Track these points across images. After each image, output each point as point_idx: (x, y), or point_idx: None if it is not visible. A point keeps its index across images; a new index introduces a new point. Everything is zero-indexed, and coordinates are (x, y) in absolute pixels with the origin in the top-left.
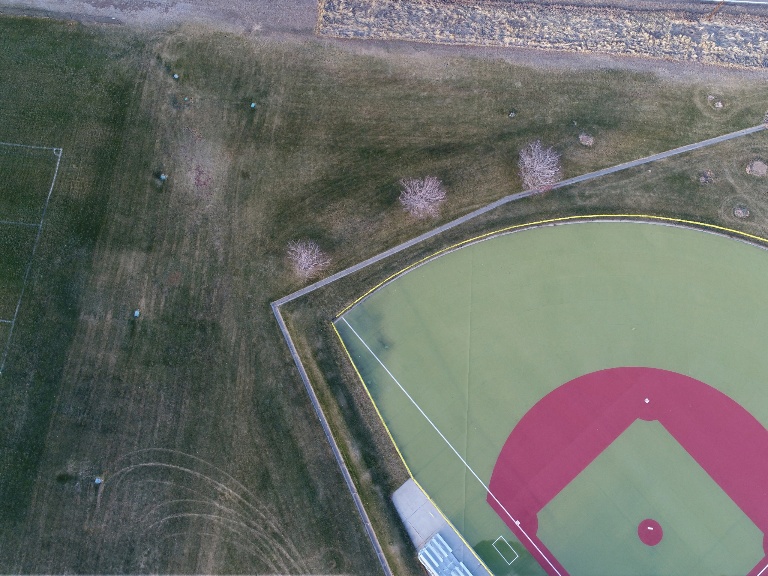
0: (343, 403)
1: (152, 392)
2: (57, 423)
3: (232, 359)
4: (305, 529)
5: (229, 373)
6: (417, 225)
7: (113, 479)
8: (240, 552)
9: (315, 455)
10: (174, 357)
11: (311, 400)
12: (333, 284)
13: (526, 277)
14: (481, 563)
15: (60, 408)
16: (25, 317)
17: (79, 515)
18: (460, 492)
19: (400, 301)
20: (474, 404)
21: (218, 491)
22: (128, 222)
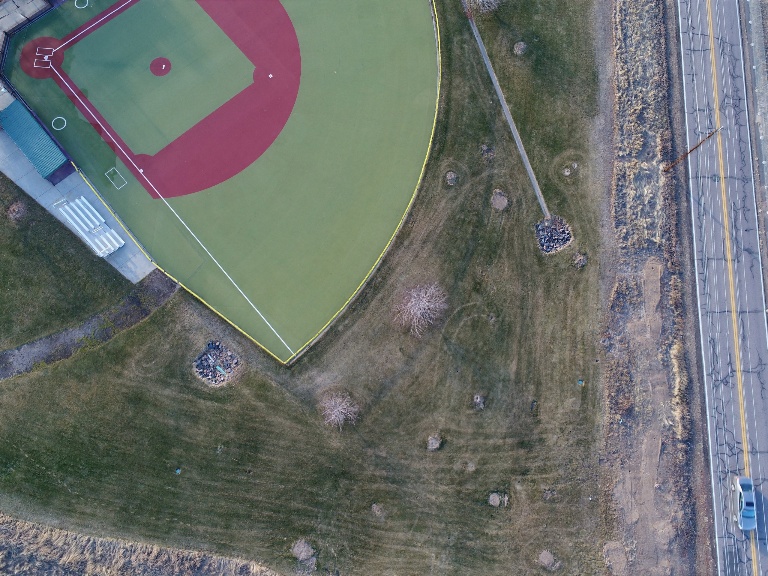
0: None
1: None
2: None
3: None
4: None
5: None
6: None
7: None
8: None
9: None
10: None
11: None
12: None
13: None
14: None
15: None
16: None
17: None
18: None
19: None
20: None
21: None
22: None
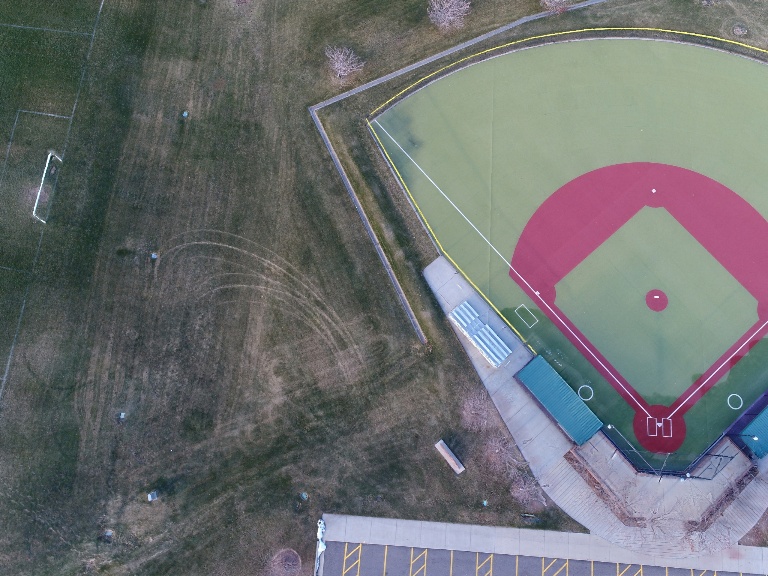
0: (377, 192)
1: (201, 182)
2: (115, 205)
3: (274, 155)
4: (345, 298)
5: (272, 167)
6: (443, 41)
7: (168, 254)
8: (286, 317)
9: (352, 236)
10: (221, 152)
11: (348, 190)
12: (366, 91)
13: (543, 86)
14: (505, 320)
15: (117, 193)
16: (82, 114)
17: (138, 284)
18: (485, 267)
19: (428, 106)
20: (497, 194)
21: (264, 266)
22: (175, 34)
